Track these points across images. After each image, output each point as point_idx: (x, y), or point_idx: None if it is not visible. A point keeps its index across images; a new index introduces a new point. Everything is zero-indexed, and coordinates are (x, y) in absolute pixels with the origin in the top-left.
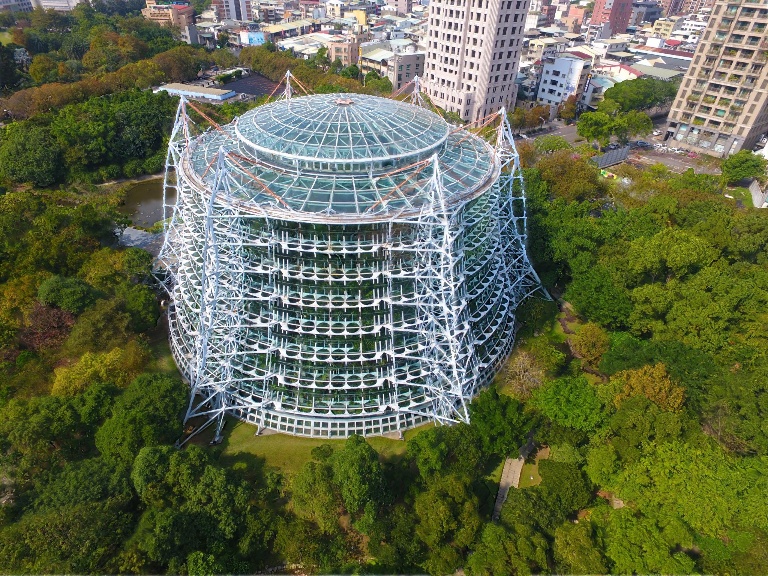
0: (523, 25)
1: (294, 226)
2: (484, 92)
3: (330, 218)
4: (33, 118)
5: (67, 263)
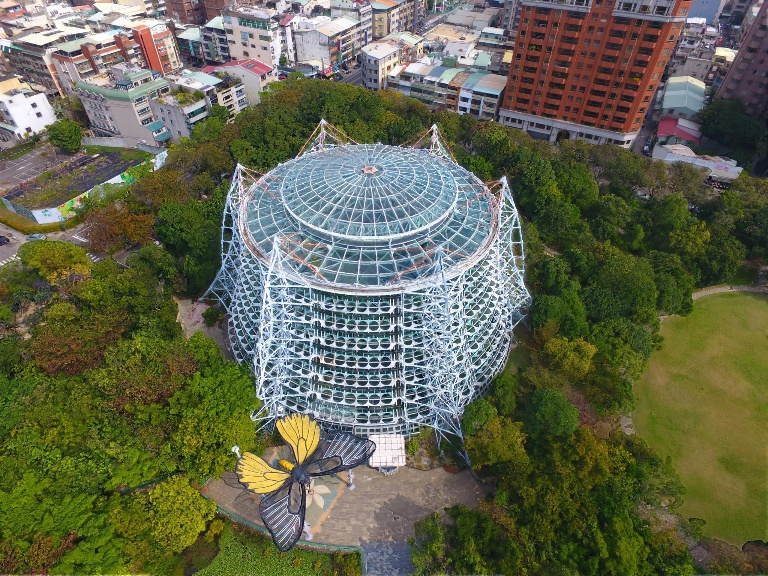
0: None
1: None
2: None
3: None
4: None
5: None
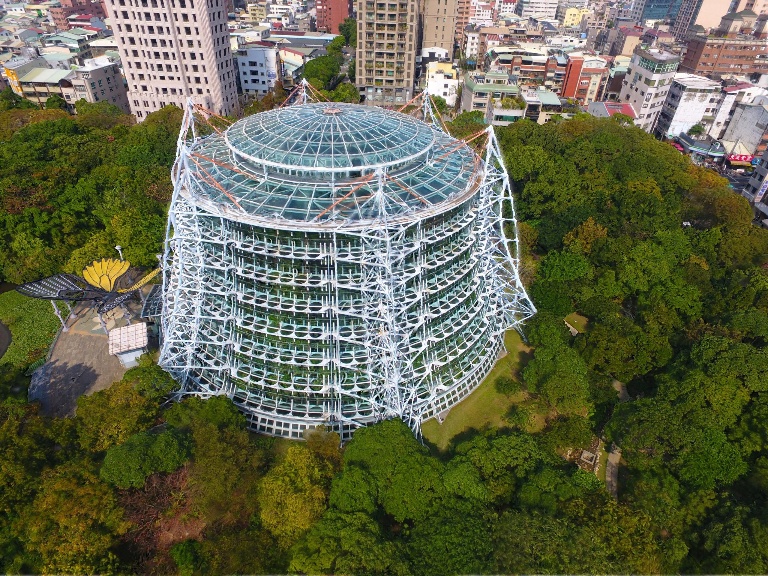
0: (225, 22)
1: (429, 221)
2: (219, 92)
3: (453, 201)
4: None
5: (59, 443)
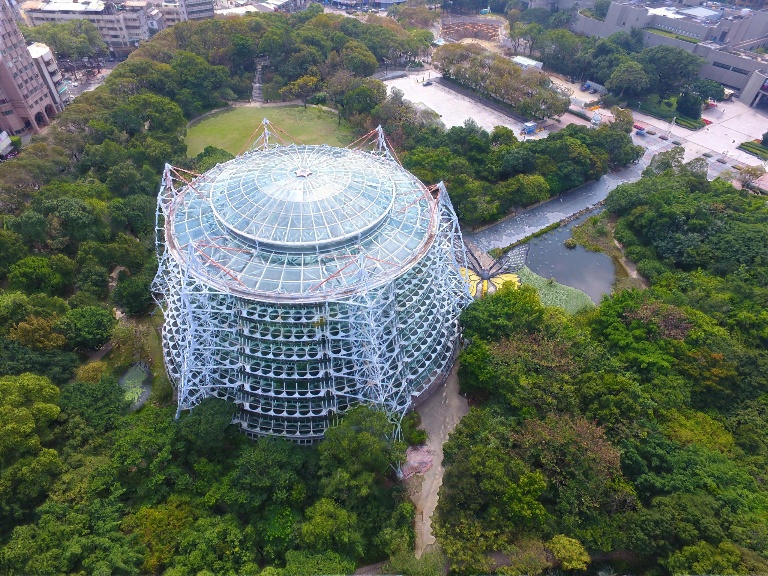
0: None
1: None
2: None
3: None
4: (701, 180)
5: None
